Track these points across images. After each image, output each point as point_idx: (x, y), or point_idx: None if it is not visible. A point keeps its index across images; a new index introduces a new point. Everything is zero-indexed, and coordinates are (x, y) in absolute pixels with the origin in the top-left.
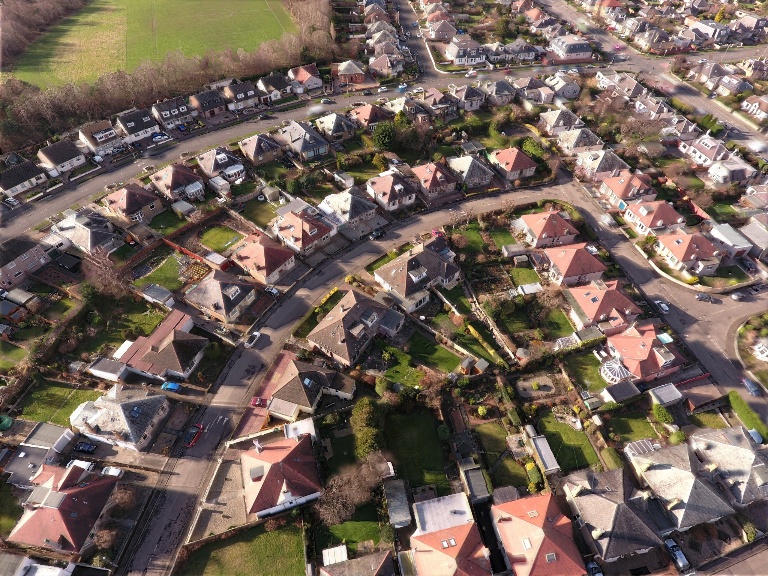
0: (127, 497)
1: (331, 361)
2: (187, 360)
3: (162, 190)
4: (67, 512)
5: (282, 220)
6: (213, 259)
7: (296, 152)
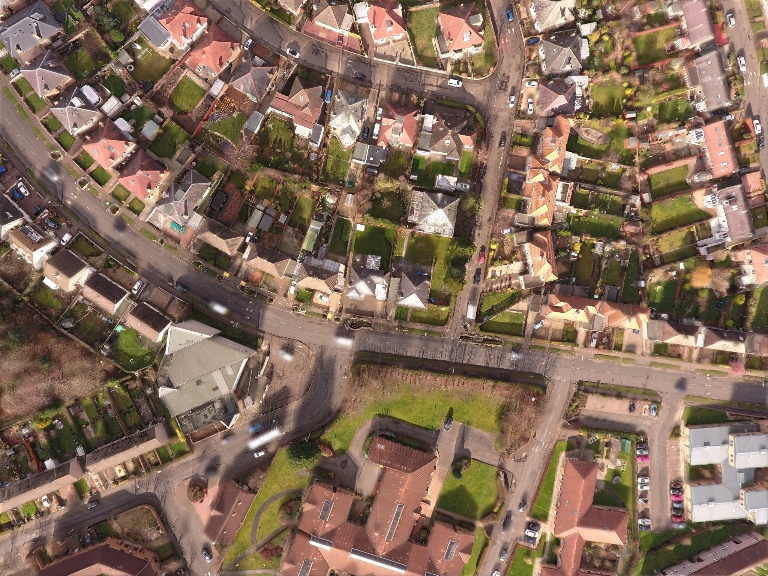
0: (396, 93)
1: (310, 0)
2: (314, 84)
3: (122, 158)
4: (405, 114)
5: (171, 38)
6: (218, 89)
7: (51, 39)
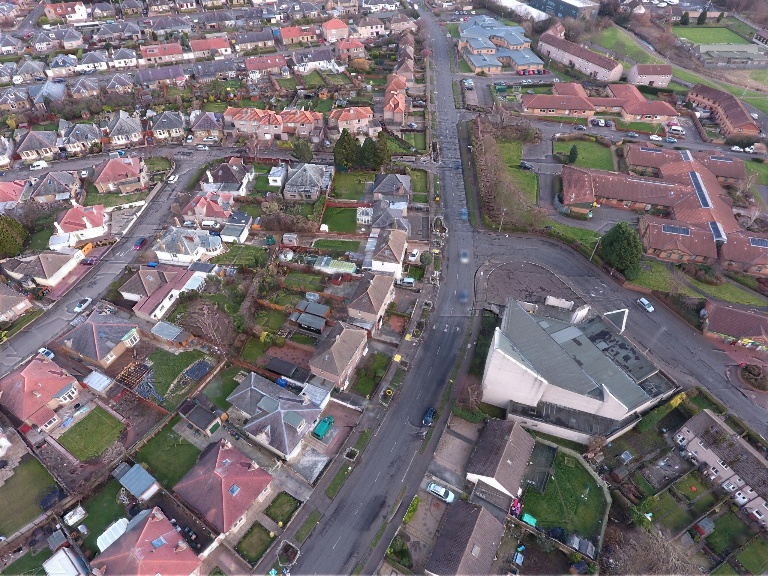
0: (171, 206)
1: None
2: None
3: None
4: None
5: None
6: (101, 379)
7: None
